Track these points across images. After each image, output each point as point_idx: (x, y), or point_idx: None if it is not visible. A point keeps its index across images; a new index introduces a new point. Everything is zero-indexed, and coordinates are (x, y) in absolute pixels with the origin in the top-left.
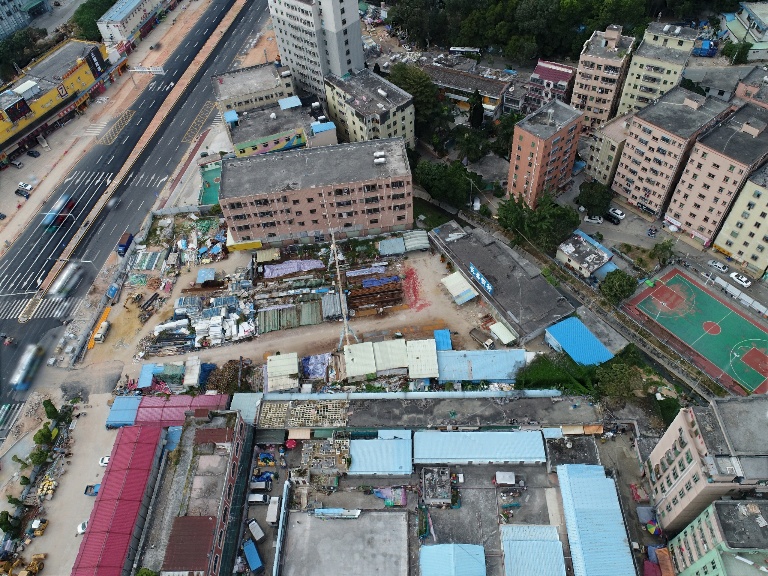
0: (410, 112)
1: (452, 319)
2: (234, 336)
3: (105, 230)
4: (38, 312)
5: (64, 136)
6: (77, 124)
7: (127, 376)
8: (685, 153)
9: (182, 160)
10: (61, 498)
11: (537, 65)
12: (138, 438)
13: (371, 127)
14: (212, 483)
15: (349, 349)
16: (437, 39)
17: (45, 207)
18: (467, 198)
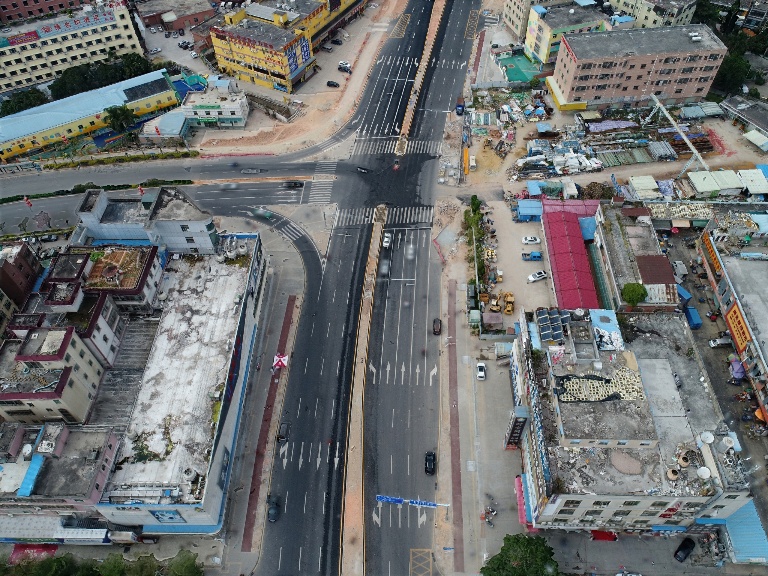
0: (692, 11)
1: (759, 162)
2: (588, 167)
3: (433, 97)
4: (409, 149)
5: (355, 31)
6: (362, 23)
7: (509, 191)
8: None
9: (473, 51)
10: (502, 262)
11: None
12: (564, 218)
13: (665, 20)
14: (645, 242)
15: None
16: None
17: (371, 80)
18: (741, 81)
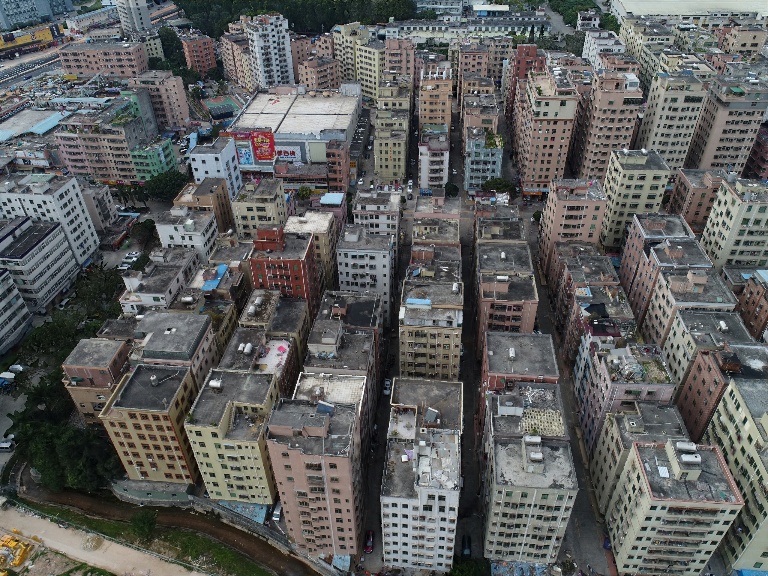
0: (159, 42)
1: None
2: None
3: None
4: None
5: (28, 56)
6: (37, 53)
7: None
8: (232, 48)
9: None
10: None
11: (224, 34)
12: None
13: None
14: None
15: (78, 90)
16: (212, 35)
17: None
18: None
